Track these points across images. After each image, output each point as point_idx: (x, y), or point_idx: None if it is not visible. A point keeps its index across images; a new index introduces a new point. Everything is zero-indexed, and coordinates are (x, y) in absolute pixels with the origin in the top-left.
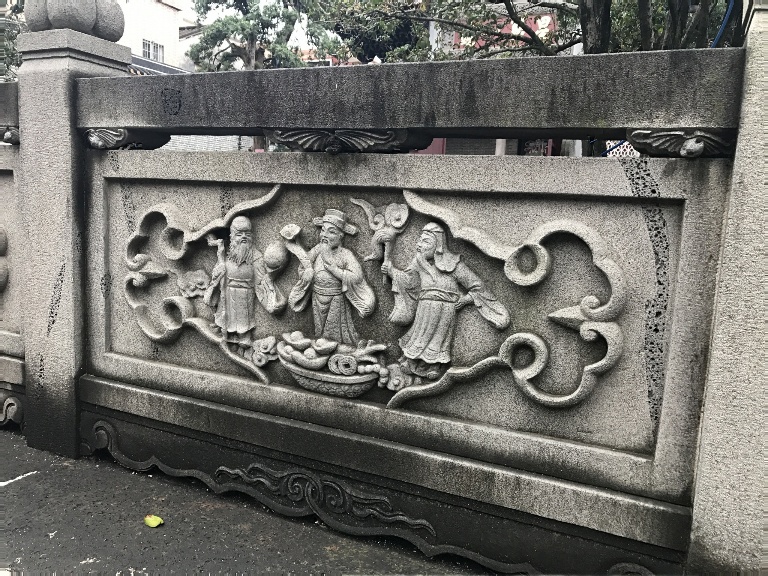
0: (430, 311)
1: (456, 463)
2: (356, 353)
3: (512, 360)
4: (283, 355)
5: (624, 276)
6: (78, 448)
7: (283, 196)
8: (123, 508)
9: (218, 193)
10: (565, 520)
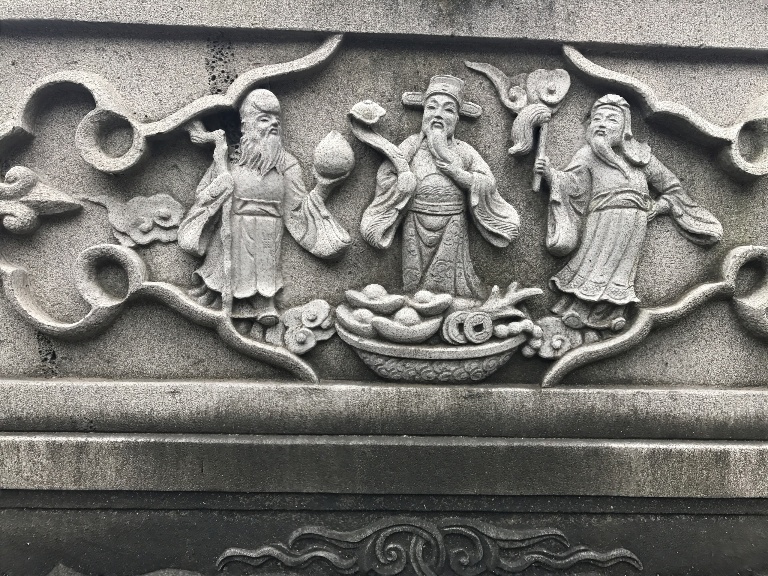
0: (619, 225)
1: (672, 448)
2: (491, 306)
3: None
4: (355, 326)
5: None
6: None
7: (338, 59)
8: None
9: (201, 53)
10: None
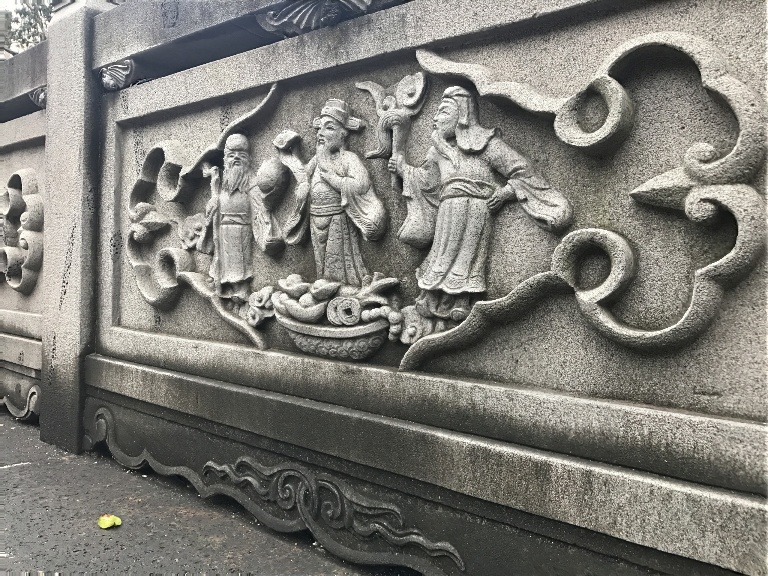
0: (451, 214)
1: (491, 448)
2: (360, 293)
3: (576, 277)
4: (276, 306)
5: (763, 101)
6: (81, 441)
7: (283, 101)
8: (87, 505)
9: (218, 115)
10: (674, 550)
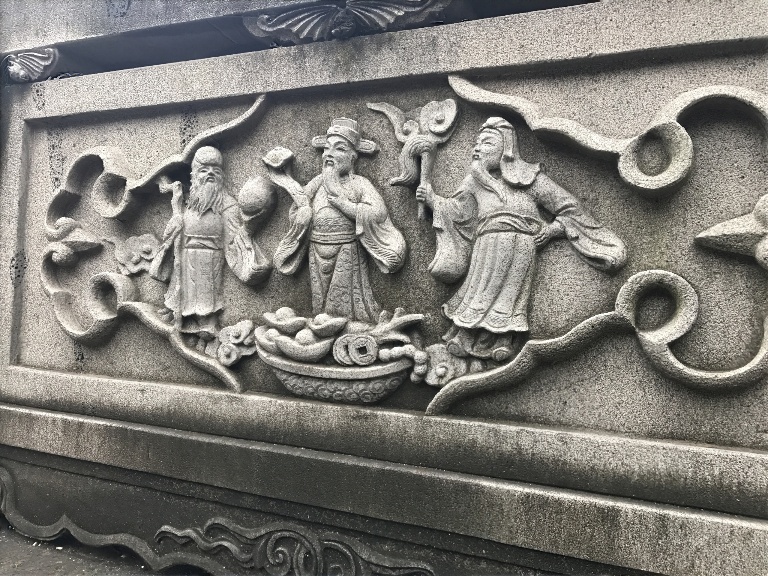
0: (496, 249)
1: (549, 496)
2: (376, 330)
3: (635, 318)
4: (263, 343)
5: None
6: None
7: (269, 115)
8: None
9: (177, 123)
10: None
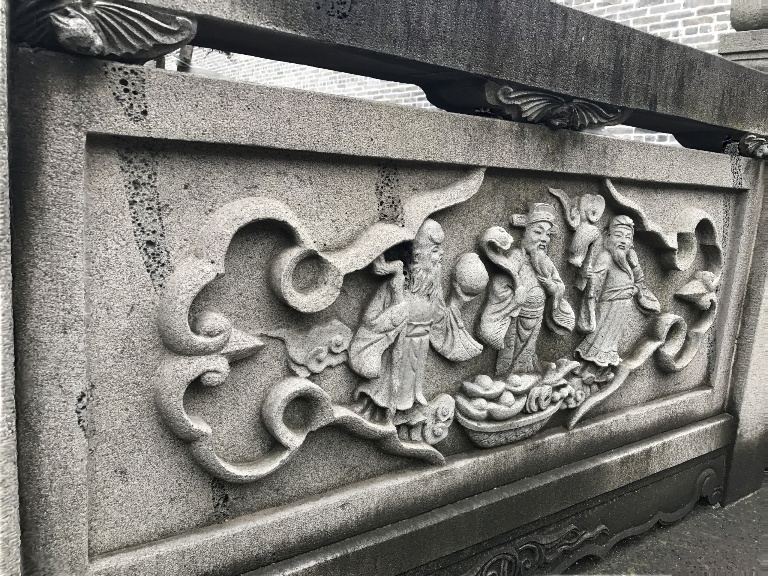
0: (622, 311)
1: (630, 454)
2: (552, 379)
3: None
4: (477, 414)
5: None
6: None
7: None
8: None
9: (373, 178)
10: (683, 461)
